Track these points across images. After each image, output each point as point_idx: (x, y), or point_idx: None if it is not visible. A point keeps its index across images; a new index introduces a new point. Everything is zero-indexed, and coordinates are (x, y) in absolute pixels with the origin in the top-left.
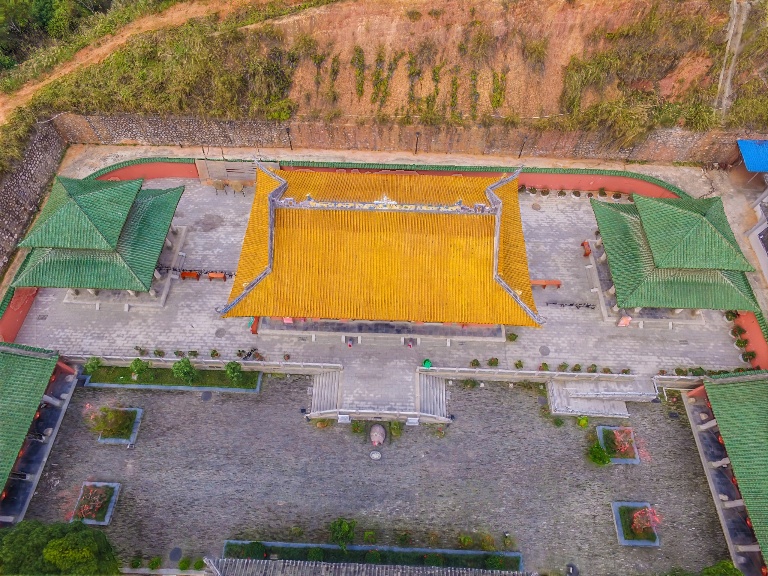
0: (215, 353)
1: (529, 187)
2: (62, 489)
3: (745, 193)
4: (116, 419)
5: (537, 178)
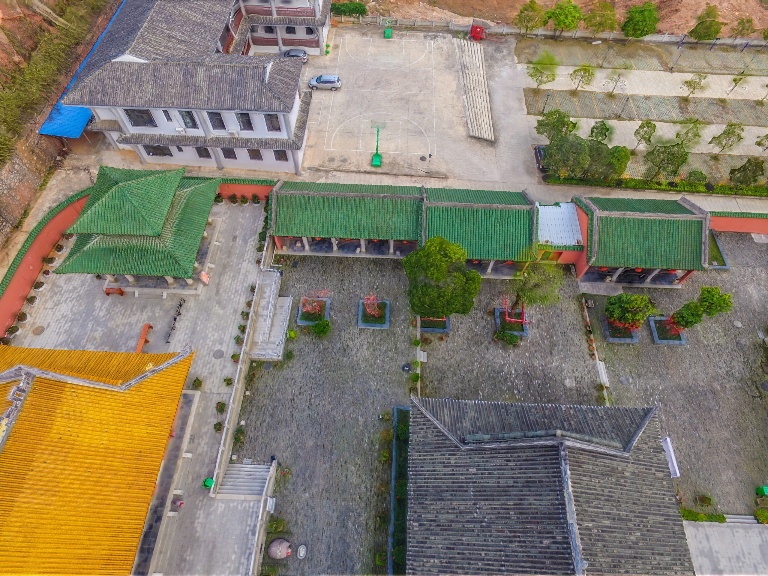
0: None
1: (5, 333)
2: None
3: (101, 149)
4: None
5: None
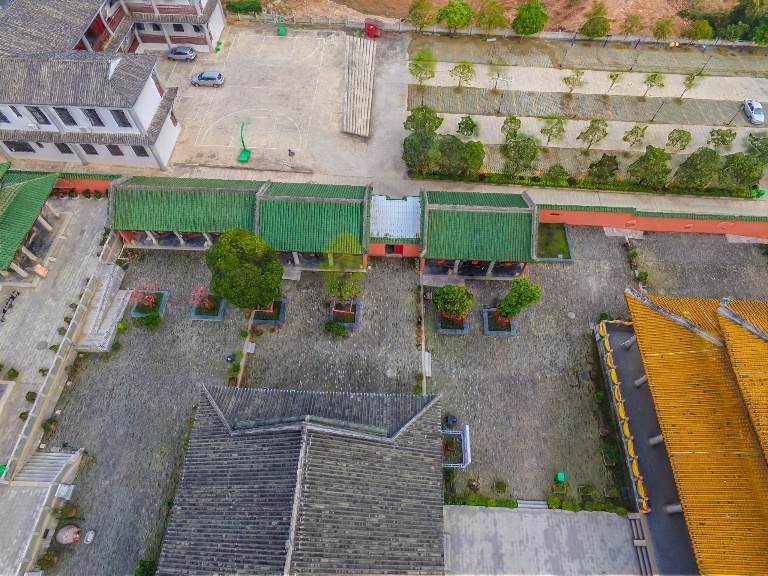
0: None
1: None
2: None
3: None
4: None
5: None
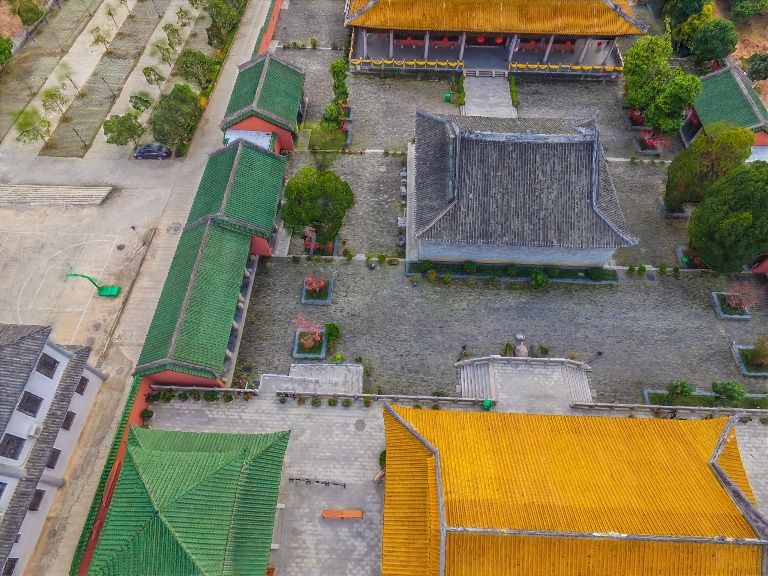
0: (710, 417)
1: None
2: (764, 316)
3: None
4: (763, 350)
5: None
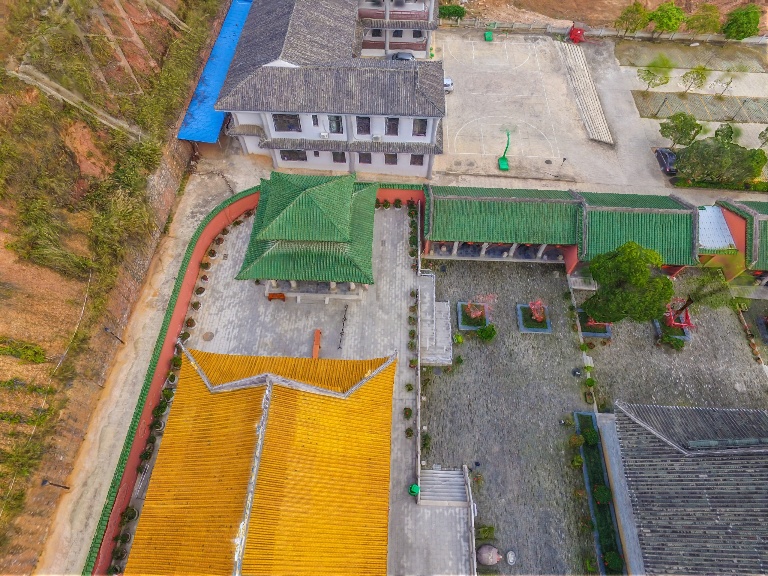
0: None
1: None
2: None
3: (230, 154)
4: None
5: (172, 328)
